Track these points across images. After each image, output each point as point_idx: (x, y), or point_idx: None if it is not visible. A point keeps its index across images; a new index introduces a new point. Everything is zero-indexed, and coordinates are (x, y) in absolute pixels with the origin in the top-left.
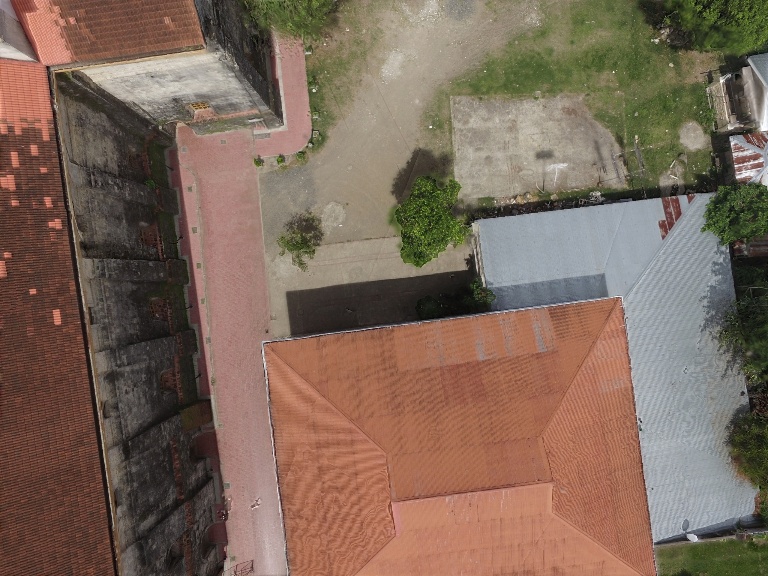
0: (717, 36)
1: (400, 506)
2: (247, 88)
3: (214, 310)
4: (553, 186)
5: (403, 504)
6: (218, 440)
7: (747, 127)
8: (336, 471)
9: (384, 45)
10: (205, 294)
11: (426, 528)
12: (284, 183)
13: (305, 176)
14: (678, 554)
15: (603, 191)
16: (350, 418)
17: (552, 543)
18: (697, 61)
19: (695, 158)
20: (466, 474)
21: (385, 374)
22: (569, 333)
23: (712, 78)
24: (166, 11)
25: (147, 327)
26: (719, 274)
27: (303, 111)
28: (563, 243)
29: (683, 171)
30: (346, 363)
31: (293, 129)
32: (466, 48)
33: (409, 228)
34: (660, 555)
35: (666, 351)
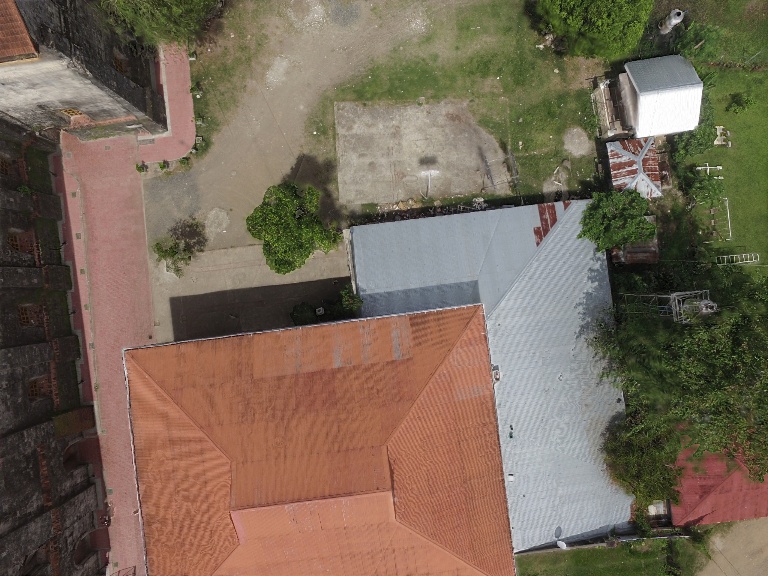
0: (586, 43)
1: (239, 515)
2: (111, 95)
3: (98, 316)
4: (437, 192)
5: (242, 513)
6: (101, 446)
7: (630, 133)
8: (188, 479)
9: (269, 51)
10: (89, 300)
11: (270, 536)
12: (168, 189)
13: (189, 182)
14: (561, 561)
15: (486, 197)
16: (200, 426)
17: (402, 551)
18: (583, 67)
19: (579, 164)
20: (307, 483)
21: (240, 382)
22: (427, 341)
23: (597, 84)
24: None
25: (13, 334)
26: (595, 281)
27: (187, 117)
28: (438, 250)
29: (567, 177)
30: (203, 370)
31: (177, 135)
32: (351, 54)
33: (256, 236)
34: (543, 562)
35: (539, 358)
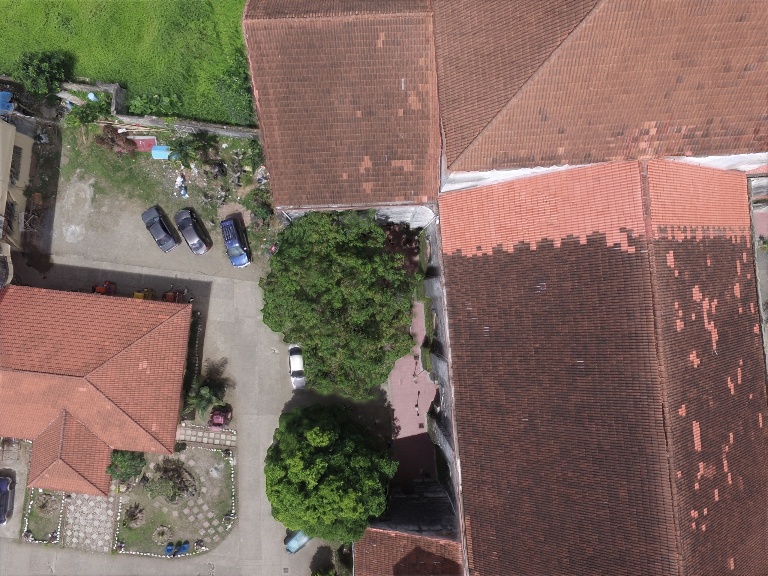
0: None
1: None
2: None
3: None
4: None
5: None
6: None
7: None
8: None
9: None
10: None
11: None
12: (763, 264)
13: None
14: None
15: None
16: None
17: None
18: None
19: None
20: None
21: None
22: None
23: None
24: None
25: None
26: None
27: None
28: None
29: None
30: None
31: None
32: None
33: None
34: None
35: None
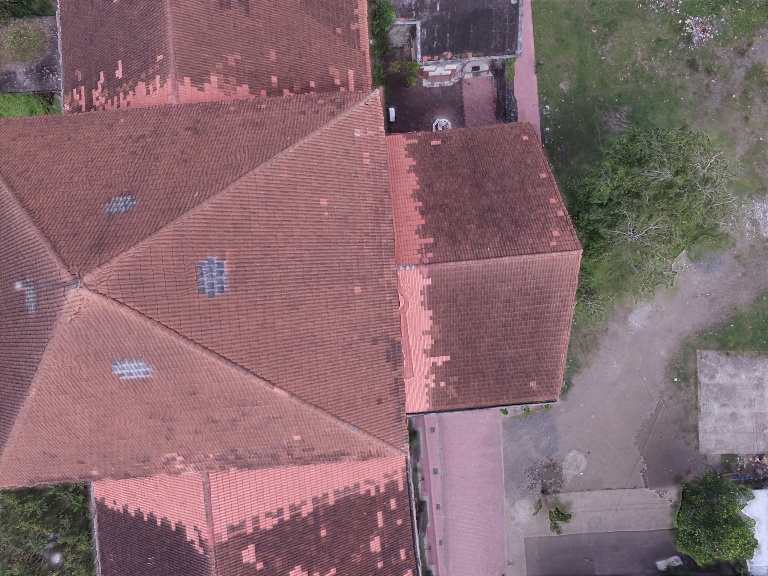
0: None
1: None
2: None
3: (451, 552)
4: None
5: None
6: None
7: None
8: None
9: None
10: (443, 535)
11: None
12: (527, 428)
13: (548, 422)
14: None
15: None
16: None
17: None
18: None
19: None
20: None
21: None
22: None
23: None
24: (534, 378)
25: None
26: None
27: None
28: None
29: None
30: None
31: None
32: (713, 301)
33: (723, 558)
34: None
35: None
